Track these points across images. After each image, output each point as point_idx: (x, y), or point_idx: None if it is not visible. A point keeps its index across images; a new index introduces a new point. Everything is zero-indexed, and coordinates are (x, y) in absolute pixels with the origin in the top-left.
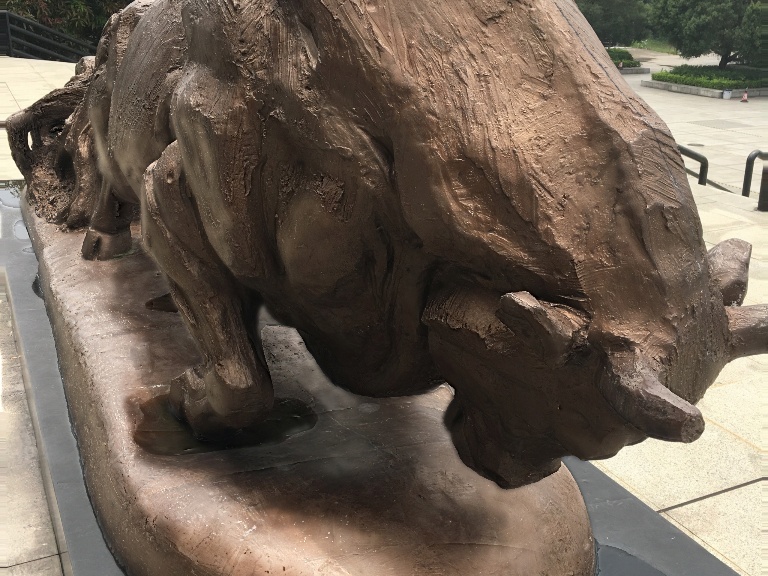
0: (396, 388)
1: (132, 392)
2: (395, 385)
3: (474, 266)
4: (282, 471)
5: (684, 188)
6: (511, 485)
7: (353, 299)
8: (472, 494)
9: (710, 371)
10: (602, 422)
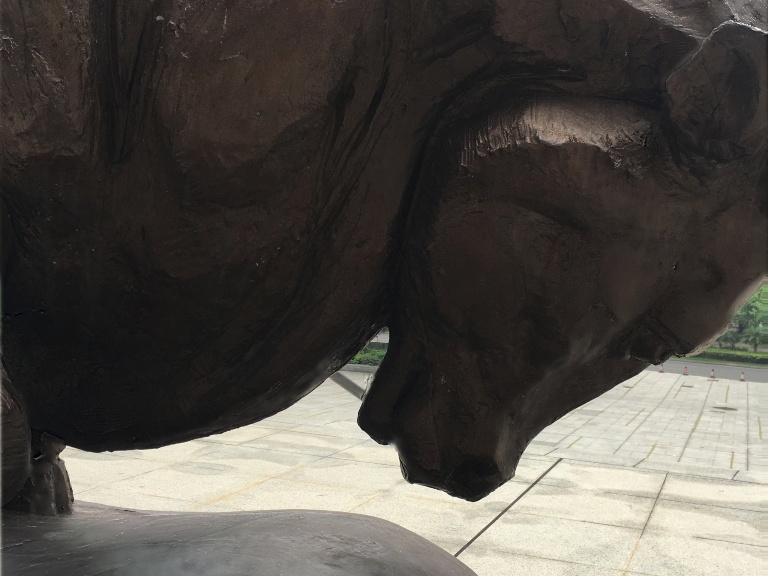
0: (291, 373)
1: None
2: (296, 364)
3: (571, 53)
4: None
5: None
6: (503, 478)
7: (282, 181)
8: (384, 549)
9: None
10: (749, 264)
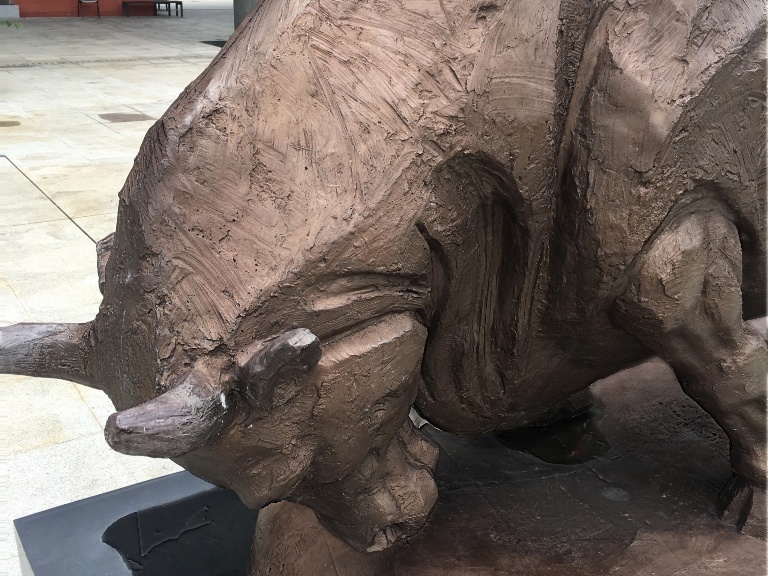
0: None
1: None
2: None
3: None
4: None
5: (146, 190)
6: None
7: None
8: (396, 544)
9: (131, 402)
10: None
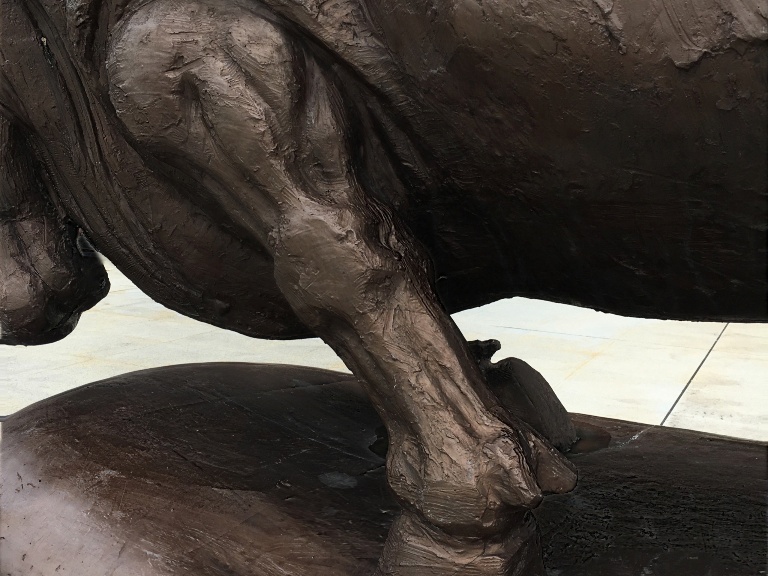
0: None
1: (637, 427)
2: None
3: None
4: (297, 379)
5: None
6: None
7: None
8: None
9: None
10: None
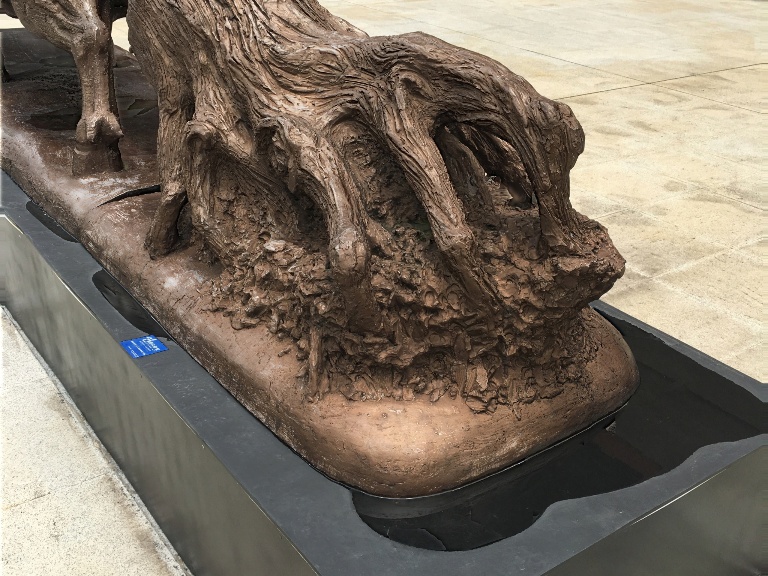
0: None
1: None
2: None
3: None
4: None
5: None
6: None
7: None
8: None
9: None
10: None
